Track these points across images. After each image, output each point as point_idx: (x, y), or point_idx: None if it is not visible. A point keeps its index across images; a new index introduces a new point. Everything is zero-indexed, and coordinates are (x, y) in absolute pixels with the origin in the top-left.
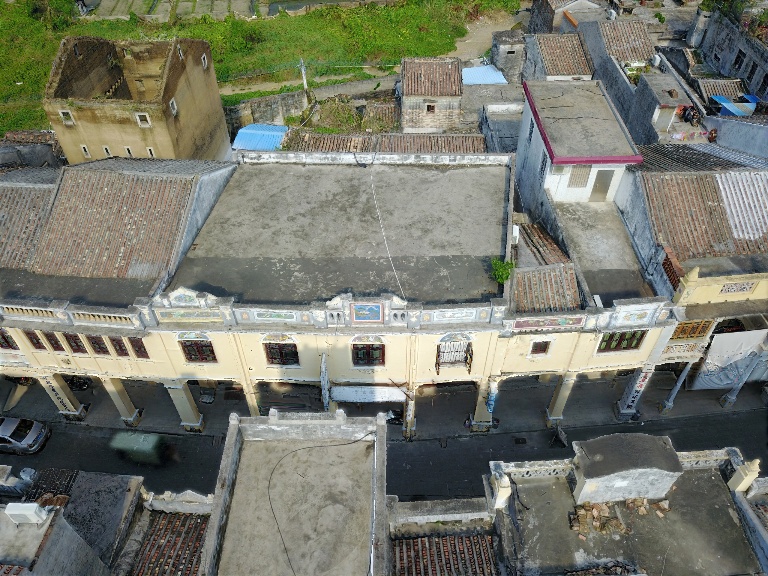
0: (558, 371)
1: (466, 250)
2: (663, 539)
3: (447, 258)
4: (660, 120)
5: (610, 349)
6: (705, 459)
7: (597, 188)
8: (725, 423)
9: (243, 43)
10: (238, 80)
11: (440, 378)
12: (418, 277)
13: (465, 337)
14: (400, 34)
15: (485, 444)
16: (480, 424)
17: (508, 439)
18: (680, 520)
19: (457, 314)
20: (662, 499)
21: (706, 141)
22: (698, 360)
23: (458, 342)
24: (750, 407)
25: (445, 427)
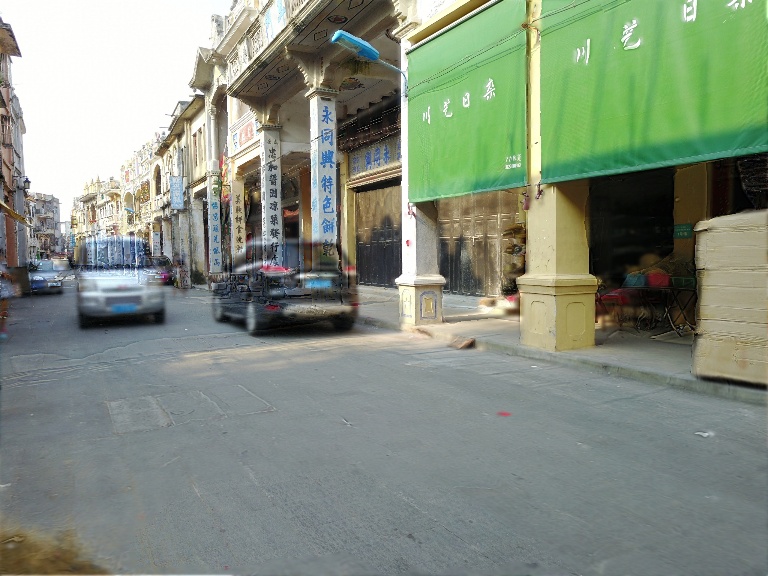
0: None
1: None
2: None
3: None
4: None
5: None
6: None
7: None
8: None
9: None
10: None
11: None
12: None
13: None
14: None
15: None
16: None
17: None
18: None
19: None
20: None
21: None
22: (91, 234)
23: None
24: None
25: None
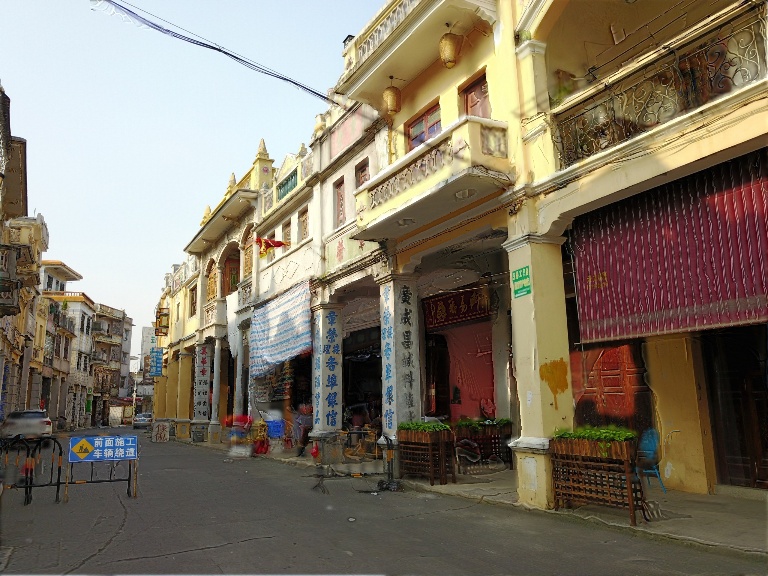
0: None
1: None
2: None
3: None
4: None
5: None
6: None
7: None
8: None
9: None
10: None
11: None
12: None
13: None
14: None
15: None
16: None
17: None
18: None
19: None
20: None
21: None
22: (215, 333)
23: None
24: None
25: None
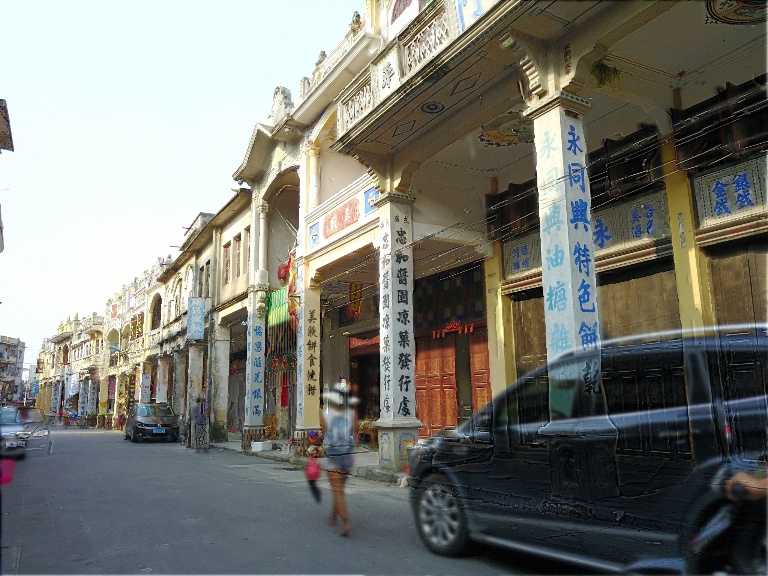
0: None
1: None
2: None
3: None
4: None
5: None
6: None
7: None
8: None
9: None
10: None
11: None
12: None
13: None
14: None
15: None
16: None
17: None
18: None
19: None
20: None
21: None
22: (60, 379)
23: None
24: None
25: None
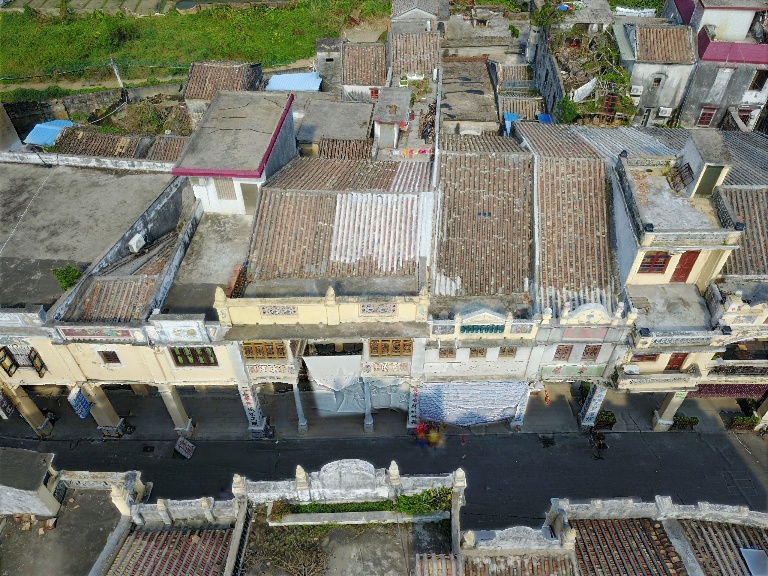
0: (149, 382)
1: (75, 255)
2: (23, 556)
3: (51, 262)
4: (383, 136)
5: (191, 364)
6: (104, 480)
7: (248, 201)
8: (359, 448)
9: (108, 40)
10: (92, 76)
11: (30, 380)
12: (8, 279)
13: (22, 341)
14: (273, 37)
15: (113, 449)
16: (105, 429)
17: (138, 446)
18: (56, 539)
19: (2, 318)
20: (52, 517)
21: (427, 159)
22: (296, 382)
23: (25, 346)
24: (392, 434)
25: (82, 429)
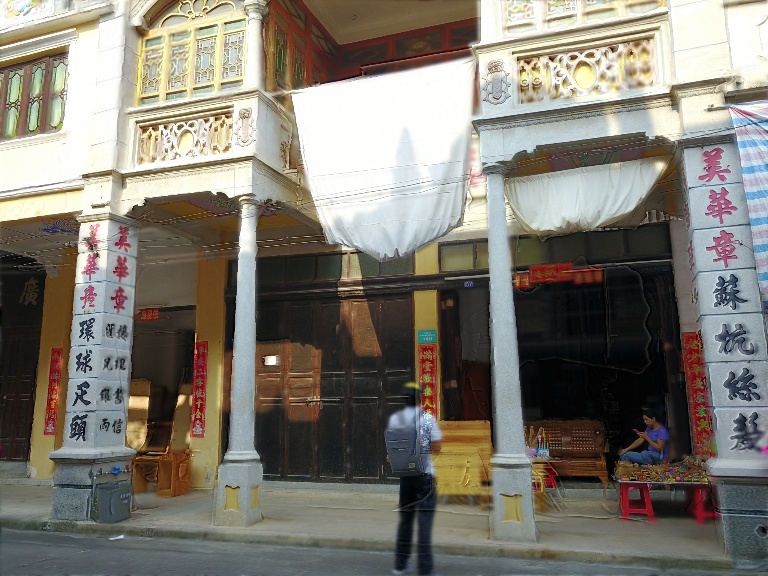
0: None
1: None
2: None
3: None
4: None
5: (8, 140)
6: None
7: None
8: (448, 568)
9: None
10: None
11: None
12: None
13: None
14: None
15: None
16: None
17: None
18: None
19: None
20: None
21: None
22: (252, 183)
23: None
24: None
25: None
